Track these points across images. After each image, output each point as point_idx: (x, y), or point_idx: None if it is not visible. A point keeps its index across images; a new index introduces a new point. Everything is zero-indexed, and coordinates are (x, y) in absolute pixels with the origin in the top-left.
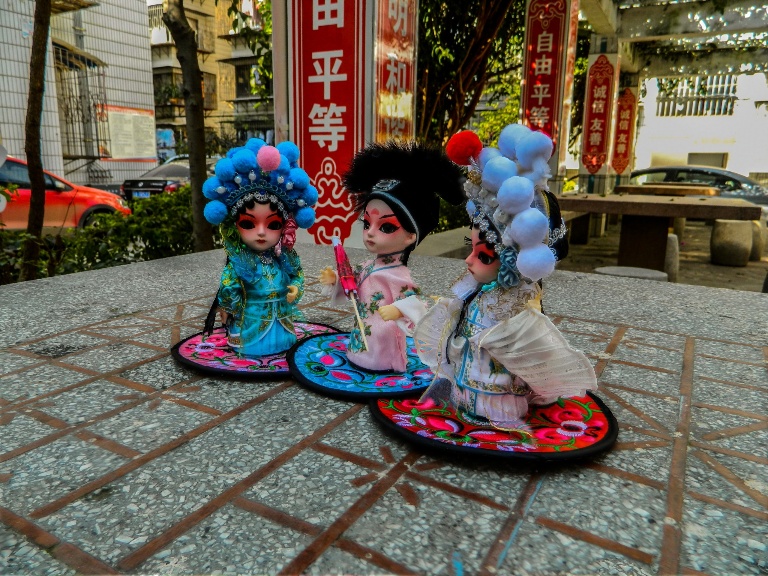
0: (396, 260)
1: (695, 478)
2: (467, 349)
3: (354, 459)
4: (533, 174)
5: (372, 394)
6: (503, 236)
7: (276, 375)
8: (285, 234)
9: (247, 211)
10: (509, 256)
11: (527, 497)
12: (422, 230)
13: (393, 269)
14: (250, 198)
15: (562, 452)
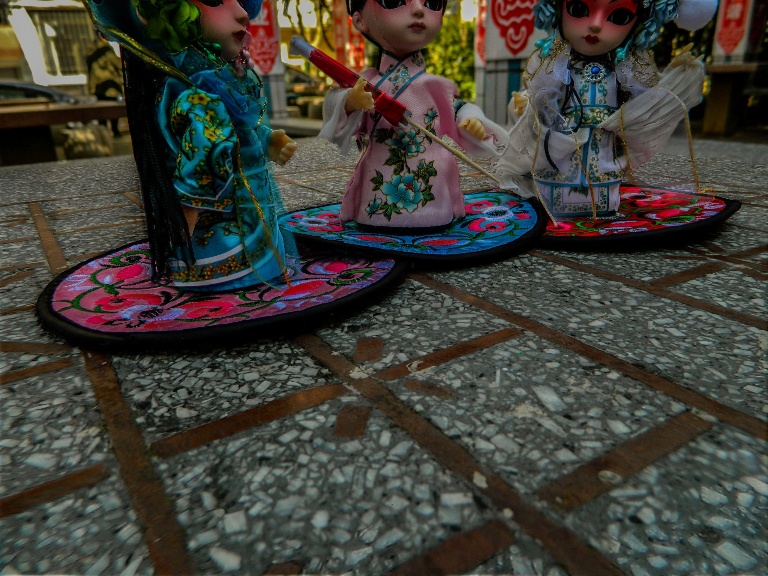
0: None
1: None
2: (589, 141)
3: (701, 271)
4: None
5: (538, 231)
6: None
7: None
8: None
9: None
10: (671, 4)
11: None
12: None
13: None
14: None
15: None
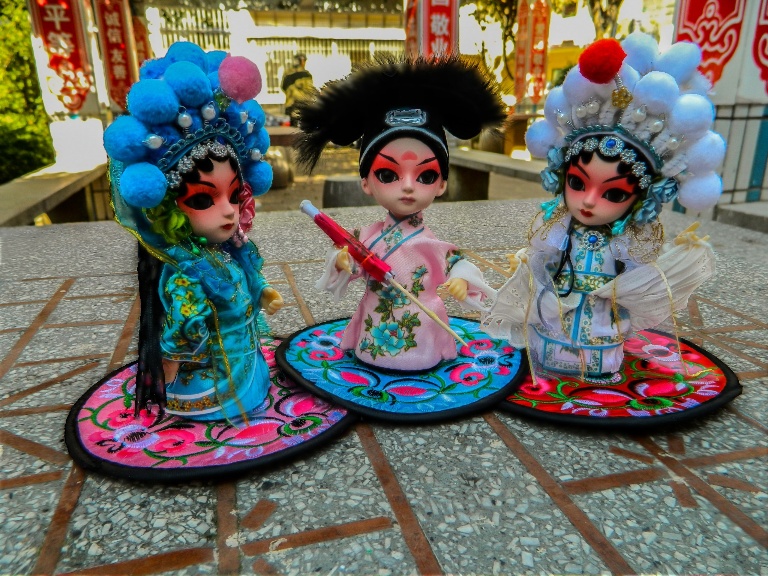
0: None
1: (761, 357)
2: (582, 305)
3: (629, 479)
4: (698, 91)
5: (499, 396)
6: (673, 166)
7: (346, 426)
8: (244, 209)
9: (202, 177)
10: (669, 188)
11: (766, 429)
12: None
13: (425, 232)
14: (204, 153)
15: (728, 375)
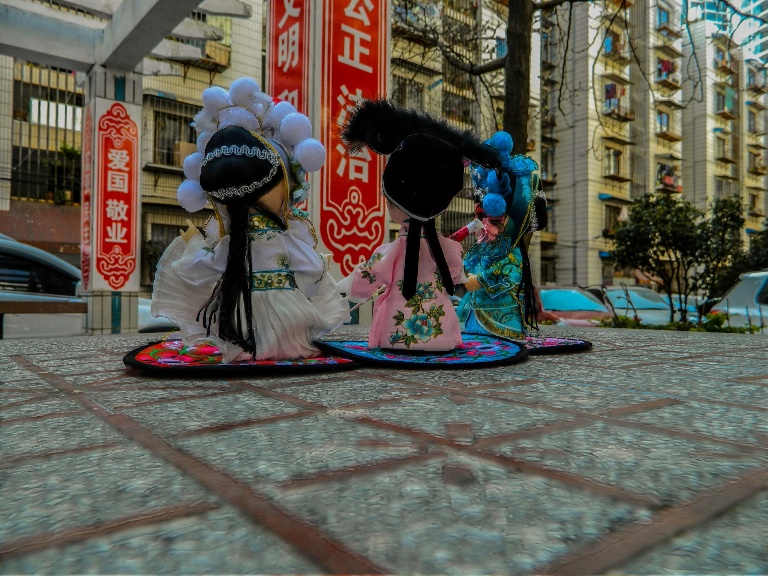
0: (401, 230)
1: None
2: None
3: None
4: None
5: None
6: None
7: None
8: None
9: None
10: None
11: None
12: (393, 192)
13: None
14: None
15: None
